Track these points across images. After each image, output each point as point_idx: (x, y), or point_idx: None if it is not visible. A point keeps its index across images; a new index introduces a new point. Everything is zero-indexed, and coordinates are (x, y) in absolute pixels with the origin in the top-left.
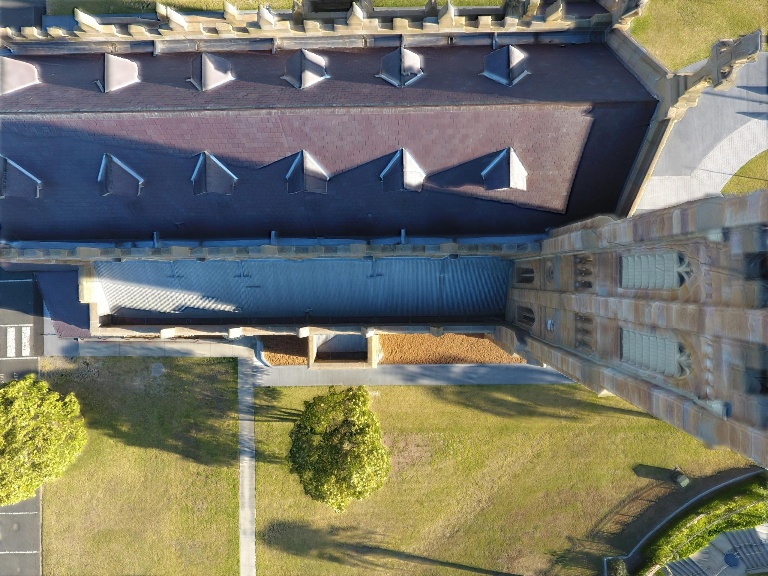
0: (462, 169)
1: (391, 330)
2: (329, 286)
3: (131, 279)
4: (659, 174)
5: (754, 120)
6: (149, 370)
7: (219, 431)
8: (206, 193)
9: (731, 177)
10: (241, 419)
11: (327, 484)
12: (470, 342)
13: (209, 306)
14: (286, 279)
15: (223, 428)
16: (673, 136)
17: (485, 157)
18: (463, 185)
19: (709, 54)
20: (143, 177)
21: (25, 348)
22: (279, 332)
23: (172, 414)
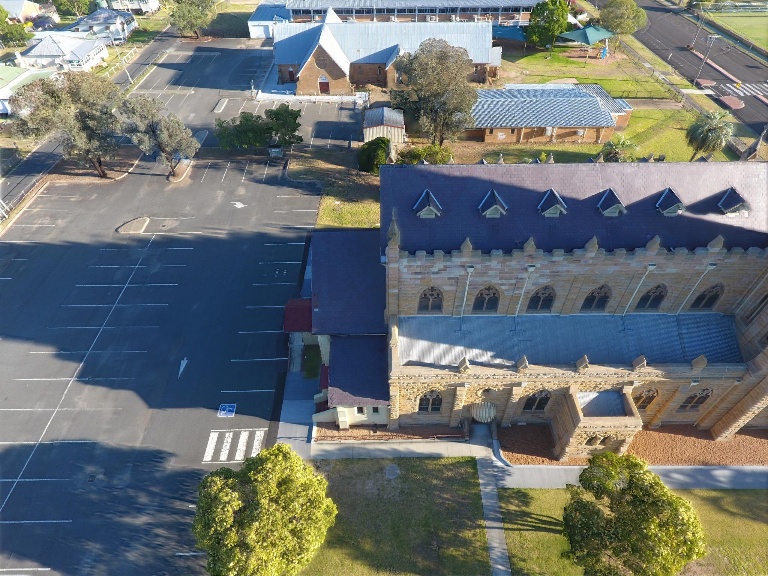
0: (706, 201)
1: (658, 366)
2: (588, 340)
3: (424, 333)
4: None
5: None
6: (383, 472)
7: (465, 543)
8: (544, 218)
9: None
10: (488, 527)
11: (653, 524)
12: (702, 444)
13: (486, 359)
14: (552, 334)
15: (469, 539)
16: None
17: (718, 193)
18: (707, 213)
19: None
20: (508, 206)
21: (255, 451)
22: (559, 369)
23: (409, 522)
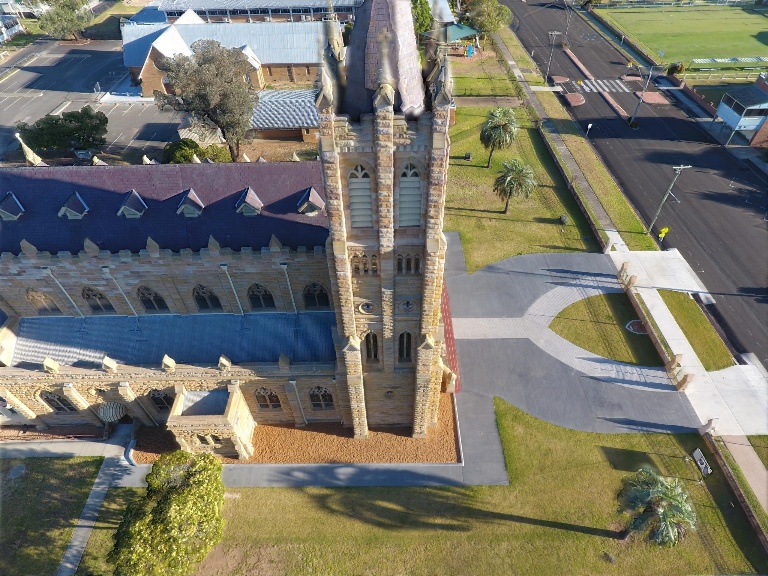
0: (285, 201)
1: (245, 365)
2: (204, 339)
3: (44, 334)
4: (497, 317)
5: (560, 286)
6: (9, 472)
7: (48, 541)
8: (125, 219)
9: (554, 318)
10: (79, 525)
11: (140, 522)
12: (340, 442)
13: (98, 360)
14: (170, 334)
15: (54, 537)
16: (503, 295)
17: (298, 193)
18: (287, 213)
19: (517, 254)
20: (90, 207)
21: None
22: (148, 369)
23: (5, 521)
